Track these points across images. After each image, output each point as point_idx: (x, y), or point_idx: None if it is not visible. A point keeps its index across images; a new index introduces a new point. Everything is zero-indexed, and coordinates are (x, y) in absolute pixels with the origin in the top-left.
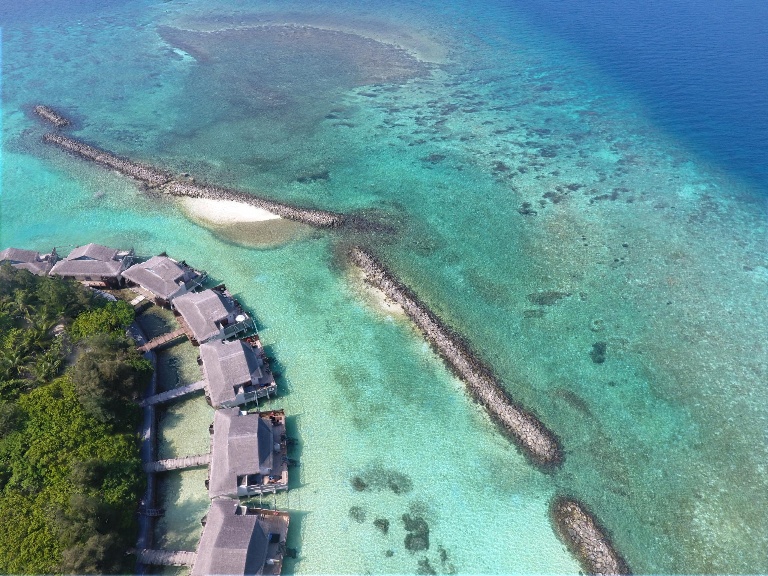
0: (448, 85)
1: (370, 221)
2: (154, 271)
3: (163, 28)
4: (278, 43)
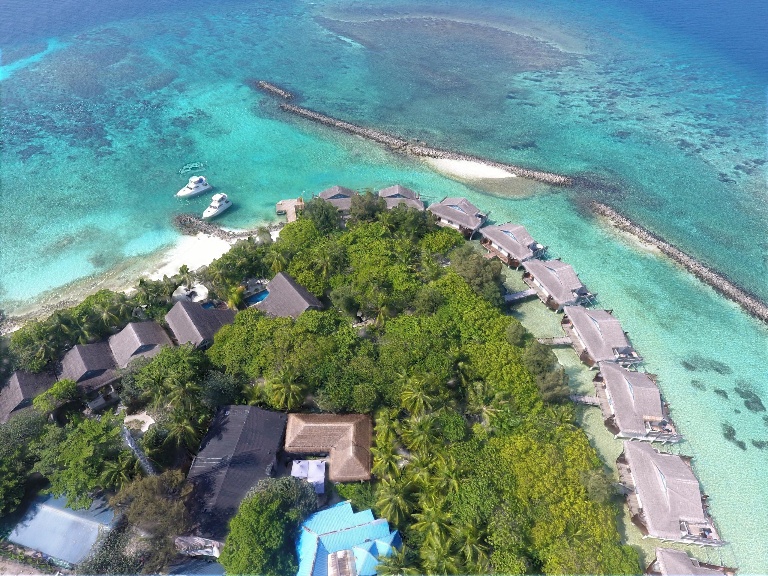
0: (601, 73)
1: (593, 182)
2: (458, 207)
3: (318, 18)
4: (427, 33)
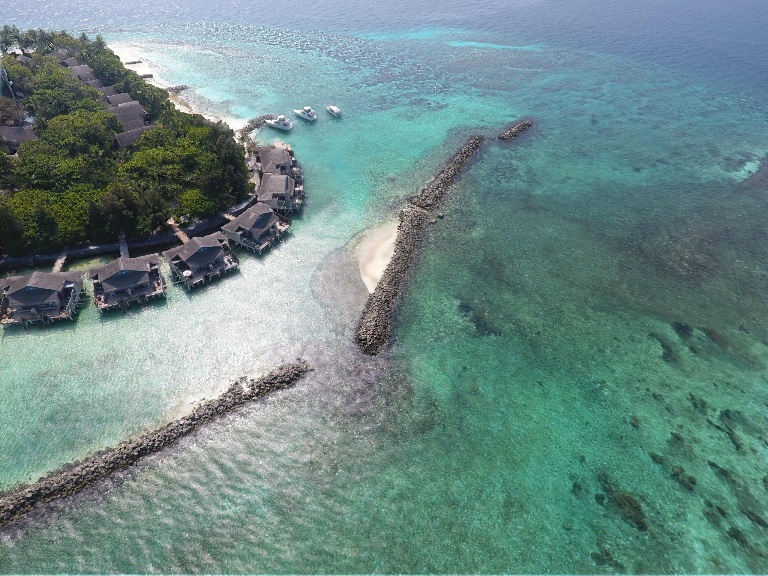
0: None
1: (375, 384)
2: None
3: None
4: None
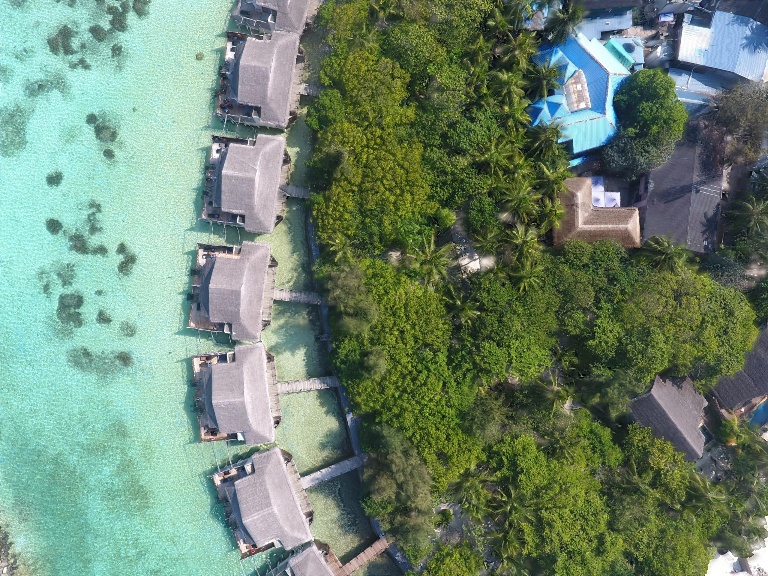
0: None
1: None
2: None
3: None
4: None
